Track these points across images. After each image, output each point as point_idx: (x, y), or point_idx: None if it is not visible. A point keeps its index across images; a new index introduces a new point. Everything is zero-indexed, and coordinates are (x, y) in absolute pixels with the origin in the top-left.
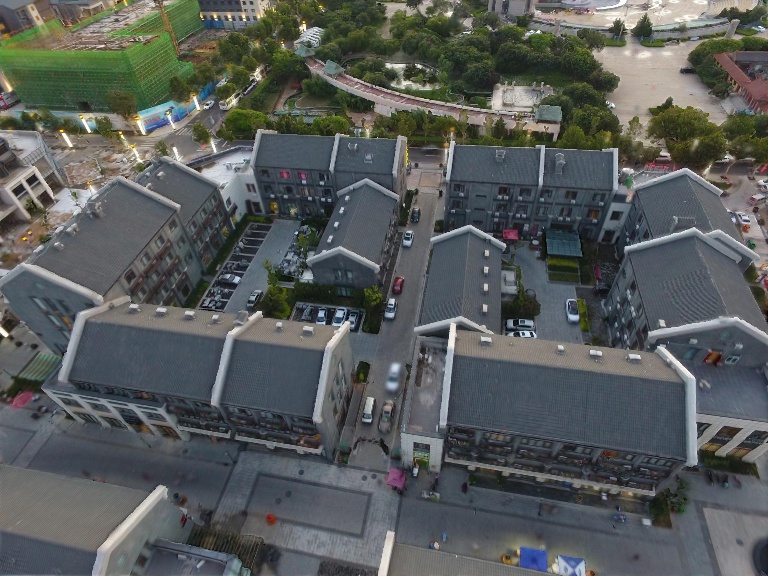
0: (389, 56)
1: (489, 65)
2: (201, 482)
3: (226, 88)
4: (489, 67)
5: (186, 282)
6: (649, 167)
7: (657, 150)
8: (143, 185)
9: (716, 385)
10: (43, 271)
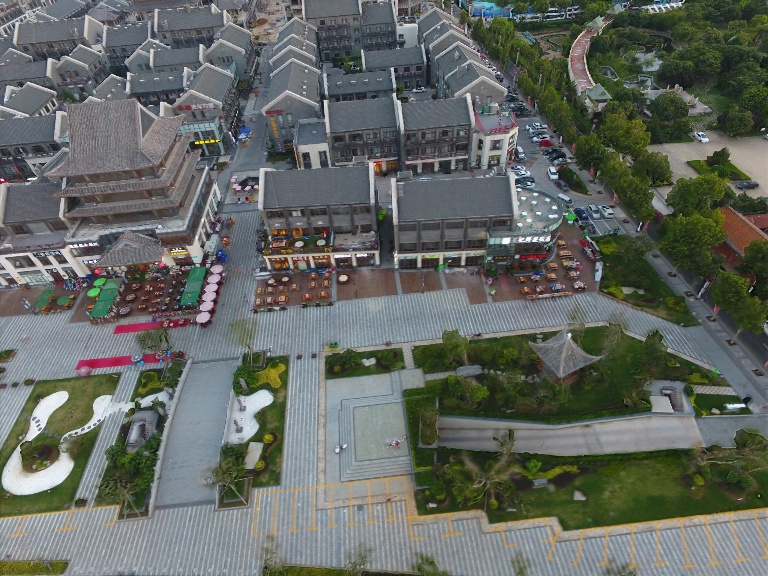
0: (674, 41)
1: (684, 65)
2: (268, 84)
3: (518, 6)
4: (681, 67)
5: (350, 50)
6: (512, 115)
7: (571, 133)
8: (371, 3)
9: (315, 135)
10: (303, 1)
